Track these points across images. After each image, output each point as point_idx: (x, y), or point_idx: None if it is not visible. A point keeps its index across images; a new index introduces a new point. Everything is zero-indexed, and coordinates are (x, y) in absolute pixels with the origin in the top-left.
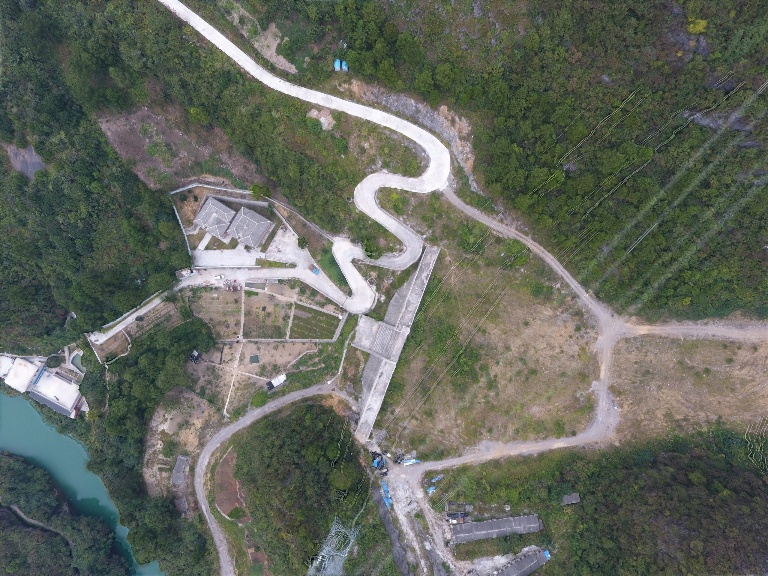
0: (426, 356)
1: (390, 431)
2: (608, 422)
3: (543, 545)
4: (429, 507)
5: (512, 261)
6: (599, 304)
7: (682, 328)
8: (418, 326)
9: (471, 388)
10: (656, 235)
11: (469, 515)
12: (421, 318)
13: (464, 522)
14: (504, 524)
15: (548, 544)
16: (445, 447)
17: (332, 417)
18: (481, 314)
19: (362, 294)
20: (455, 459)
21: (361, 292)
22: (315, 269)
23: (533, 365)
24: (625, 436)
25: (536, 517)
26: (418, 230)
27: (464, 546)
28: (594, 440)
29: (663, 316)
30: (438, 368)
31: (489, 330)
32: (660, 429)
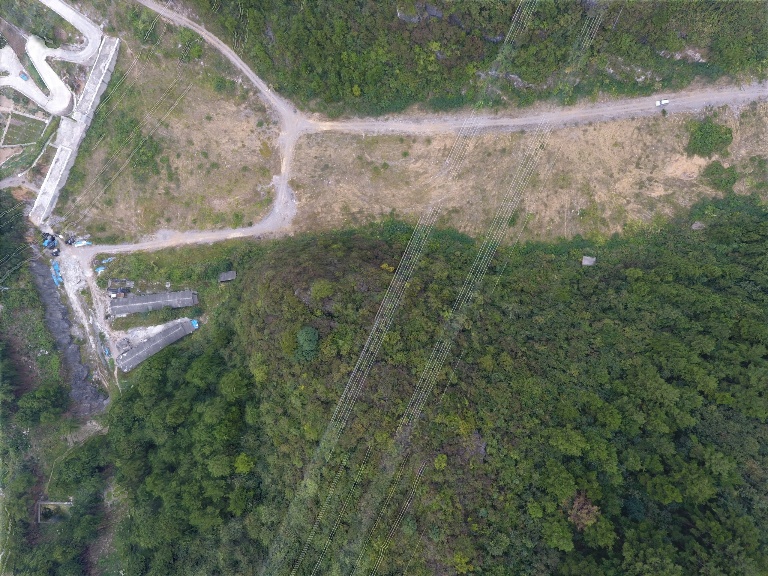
0: (108, 147)
1: (70, 218)
2: (285, 214)
3: (195, 317)
4: (96, 285)
5: (188, 52)
6: (281, 100)
7: (364, 124)
8: (100, 118)
9: (152, 179)
10: (305, 11)
11: (131, 291)
12: (103, 110)
13: (125, 297)
14: (159, 297)
15: (200, 316)
16: (123, 234)
17: (3, 197)
18: (165, 109)
19: (60, 95)
20: (131, 245)
21: (59, 92)
22: (22, 74)
23: (215, 159)
24: (300, 227)
25: (192, 292)
26: (95, 20)
27: (123, 319)
28: (269, 230)
29: (345, 112)
30: (119, 159)
31: (172, 124)
32: (336, 221)
